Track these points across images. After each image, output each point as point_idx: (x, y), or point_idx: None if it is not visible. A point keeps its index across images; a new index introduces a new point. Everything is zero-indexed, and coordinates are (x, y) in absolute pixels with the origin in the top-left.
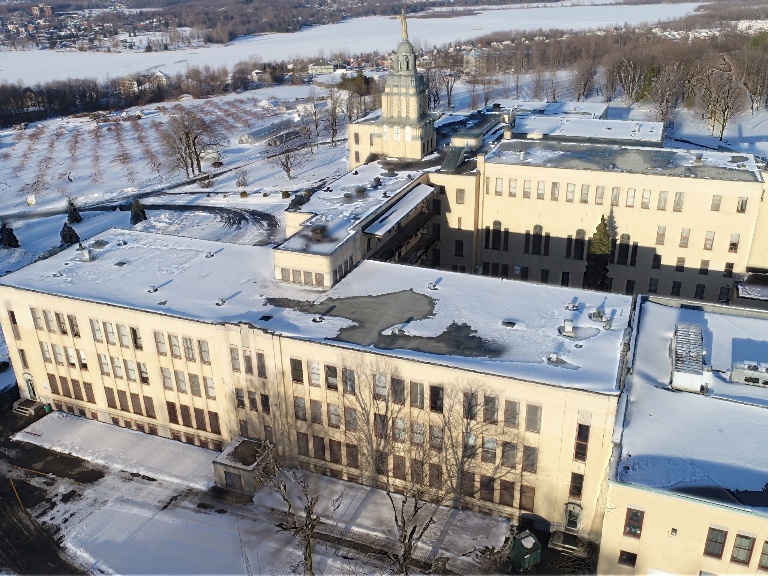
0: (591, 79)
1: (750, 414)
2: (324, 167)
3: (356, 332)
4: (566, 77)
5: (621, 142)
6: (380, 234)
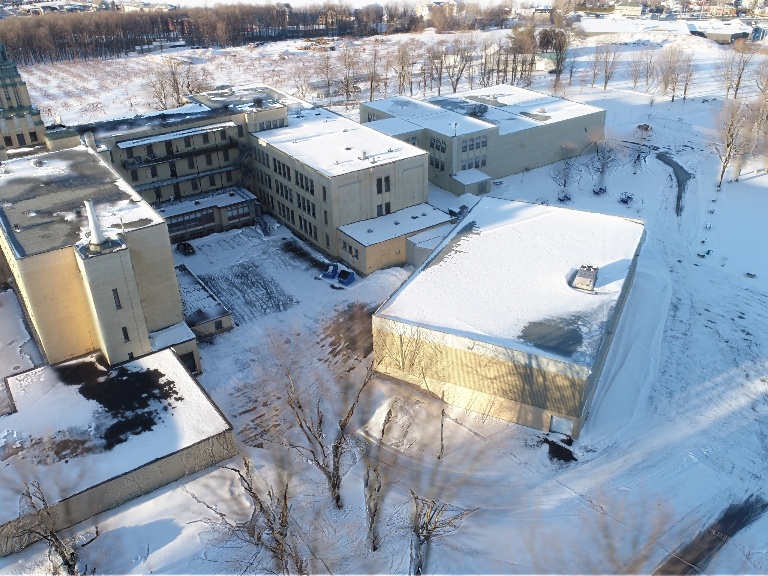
0: (748, 66)
1: None
2: None
3: None
4: (710, 59)
5: (307, 169)
6: None
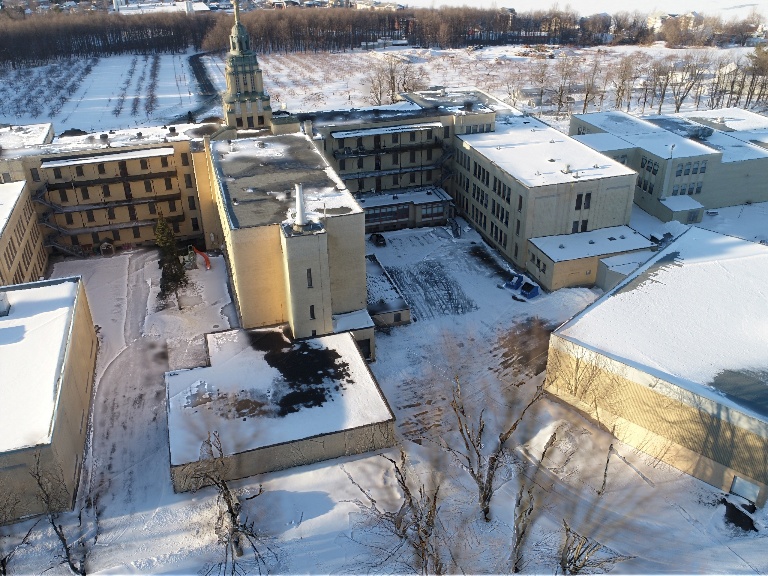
0: None
1: None
2: None
3: None
4: None
5: (507, 176)
6: (42, 167)
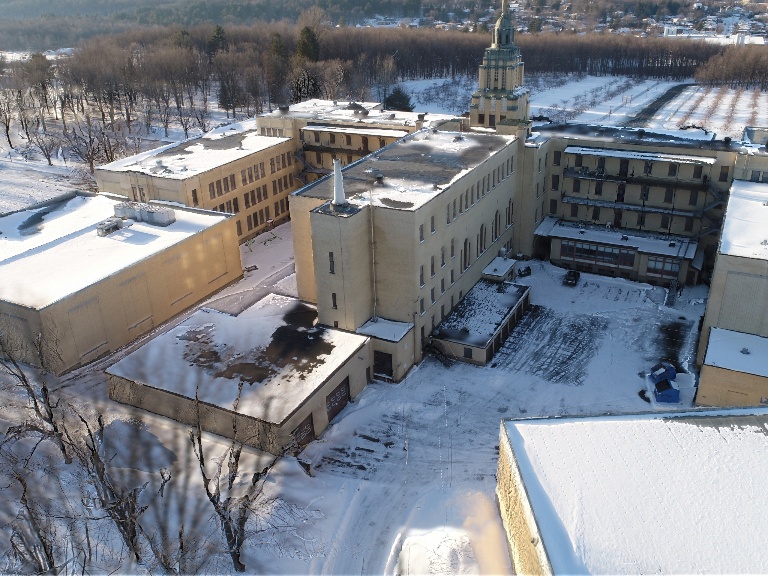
0: None
1: (87, 224)
2: None
3: None
4: None
5: None
6: (302, 128)
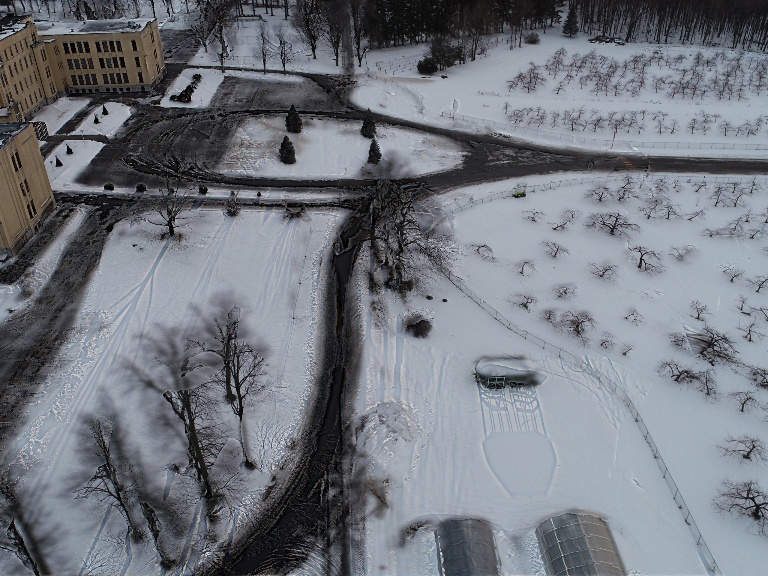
0: None
1: None
2: (133, 277)
3: None
4: None
5: None
6: None
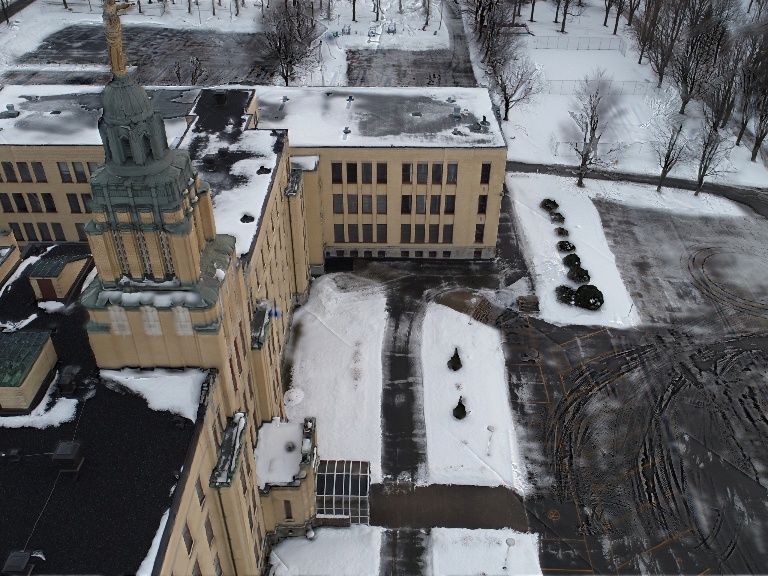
0: None
1: None
2: None
3: (170, 95)
4: None
5: None
6: (171, 138)
